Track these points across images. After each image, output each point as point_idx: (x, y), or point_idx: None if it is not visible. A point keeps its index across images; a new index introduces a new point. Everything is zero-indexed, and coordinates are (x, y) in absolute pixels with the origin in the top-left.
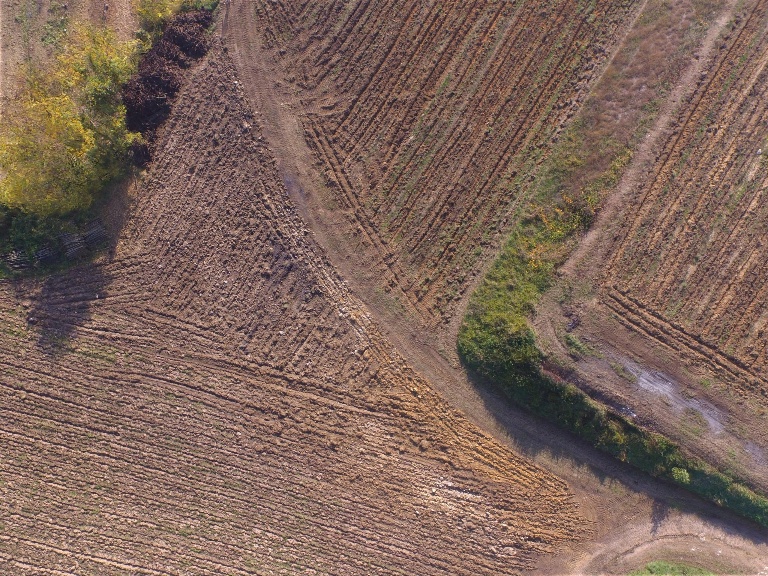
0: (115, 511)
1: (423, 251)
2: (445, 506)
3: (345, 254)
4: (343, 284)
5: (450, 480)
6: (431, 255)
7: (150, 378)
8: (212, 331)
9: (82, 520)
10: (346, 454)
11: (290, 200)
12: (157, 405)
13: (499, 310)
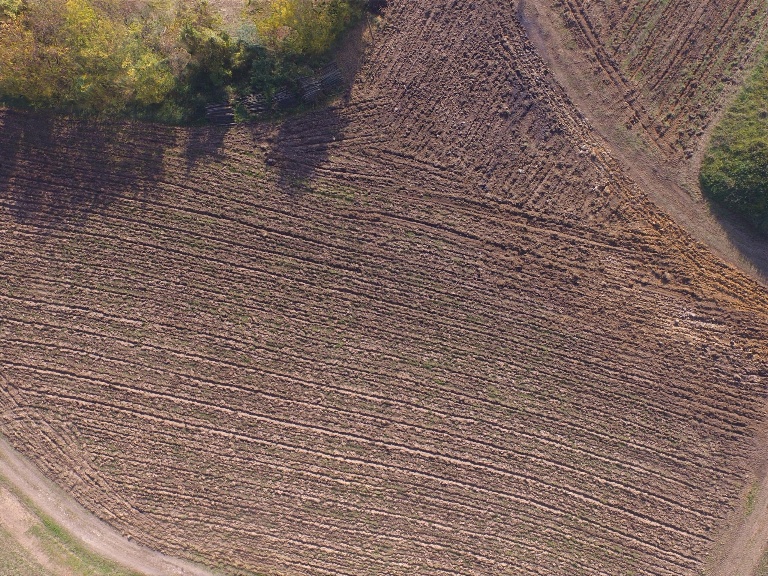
0: (359, 345)
1: (664, 88)
2: (688, 336)
3: (585, 92)
4: (584, 122)
5: (693, 311)
6: (672, 92)
7: (389, 217)
8: (450, 171)
9: (327, 353)
10: (588, 288)
11: (529, 41)
12: (397, 242)
13: (753, 136)
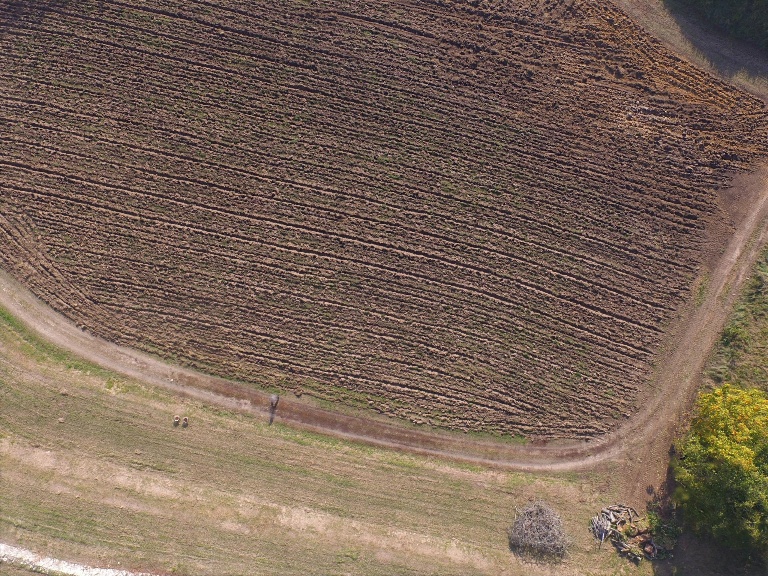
0: (314, 140)
1: None
2: (641, 130)
3: None
4: None
5: (646, 105)
6: None
7: (346, 16)
8: None
9: (282, 148)
10: (542, 83)
11: None
12: (353, 41)
13: None
